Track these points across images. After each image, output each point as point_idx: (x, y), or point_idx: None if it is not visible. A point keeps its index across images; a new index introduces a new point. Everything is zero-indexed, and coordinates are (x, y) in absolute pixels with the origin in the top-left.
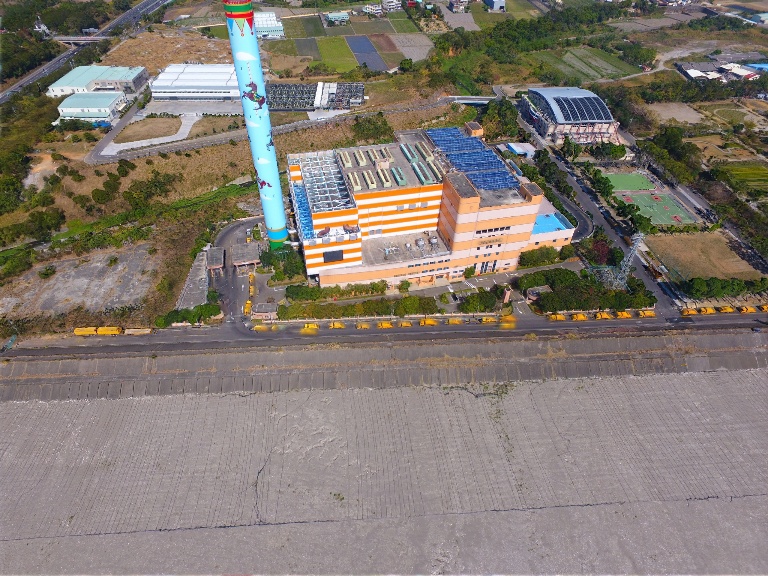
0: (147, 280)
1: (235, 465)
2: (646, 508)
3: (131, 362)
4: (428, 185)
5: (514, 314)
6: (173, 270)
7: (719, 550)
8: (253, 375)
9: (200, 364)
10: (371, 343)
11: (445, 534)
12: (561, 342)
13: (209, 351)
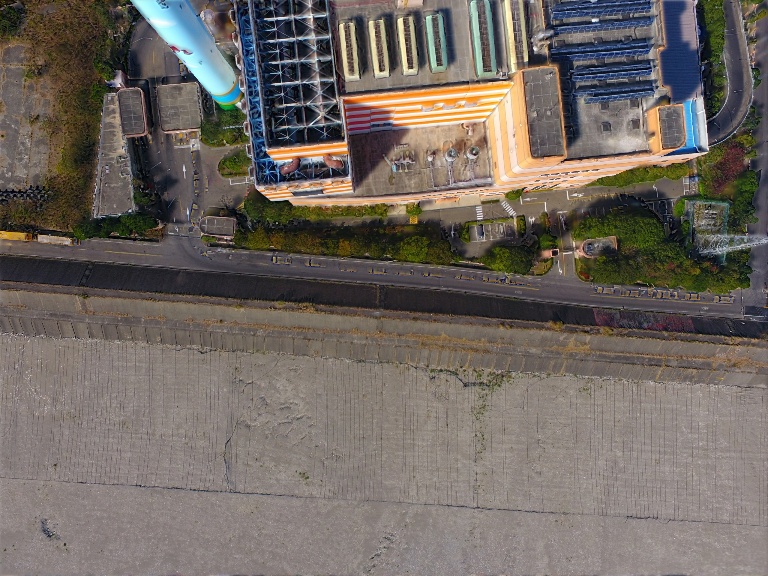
0: (41, 138)
1: (202, 433)
2: (586, 521)
3: (59, 299)
4: (485, 84)
5: (550, 273)
6: (75, 121)
7: (628, 559)
8: (210, 331)
9: (144, 310)
10: (354, 309)
11: (396, 519)
12: (590, 337)
13: (152, 296)
